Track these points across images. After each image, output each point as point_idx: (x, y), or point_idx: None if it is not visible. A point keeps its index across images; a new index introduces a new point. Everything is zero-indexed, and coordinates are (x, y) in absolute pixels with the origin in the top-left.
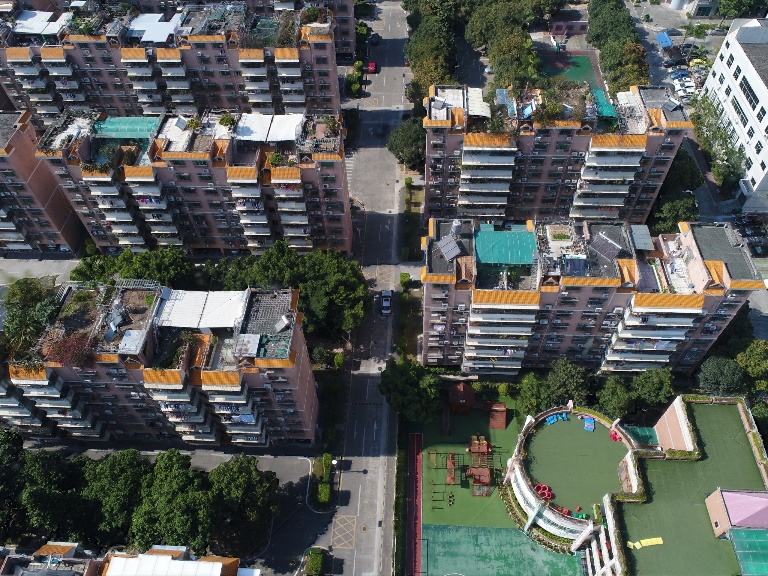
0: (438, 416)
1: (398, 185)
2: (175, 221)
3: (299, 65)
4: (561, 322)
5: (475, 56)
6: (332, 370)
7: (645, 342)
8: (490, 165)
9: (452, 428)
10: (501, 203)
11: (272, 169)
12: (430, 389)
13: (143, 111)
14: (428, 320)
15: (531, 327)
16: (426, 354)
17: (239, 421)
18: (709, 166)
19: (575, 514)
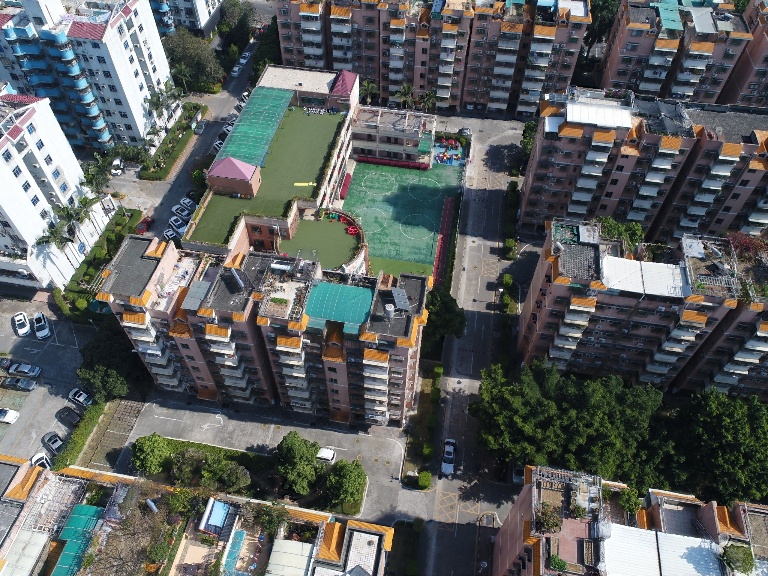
0: None
1: None
2: None
3: None
4: None
5: None
6: None
7: None
8: None
9: None
10: None
11: None
12: None
13: None
14: None
15: None
16: None
17: None
18: None
19: None
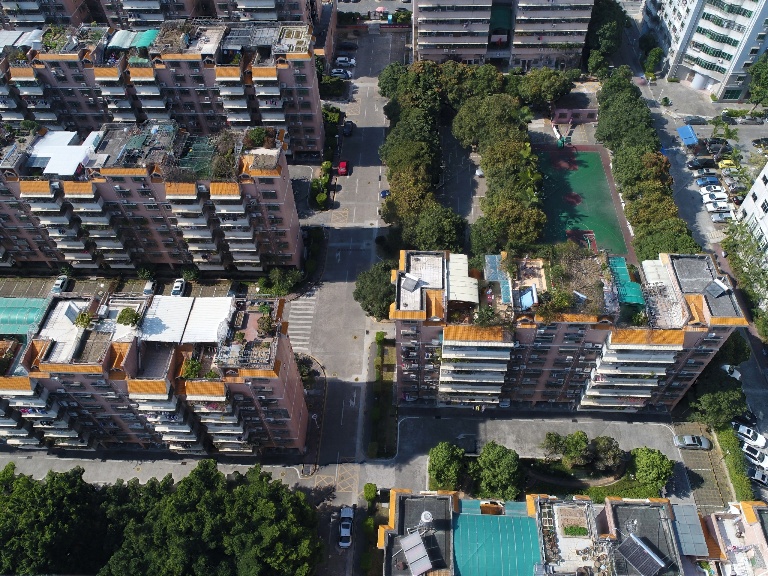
0: None
1: (368, 338)
2: (74, 423)
3: (241, 201)
4: None
5: (464, 152)
6: None
7: None
8: (478, 359)
9: None
10: (493, 391)
11: (187, 383)
12: None
13: (57, 245)
14: None
15: None
16: None
17: None
18: (751, 314)
19: None
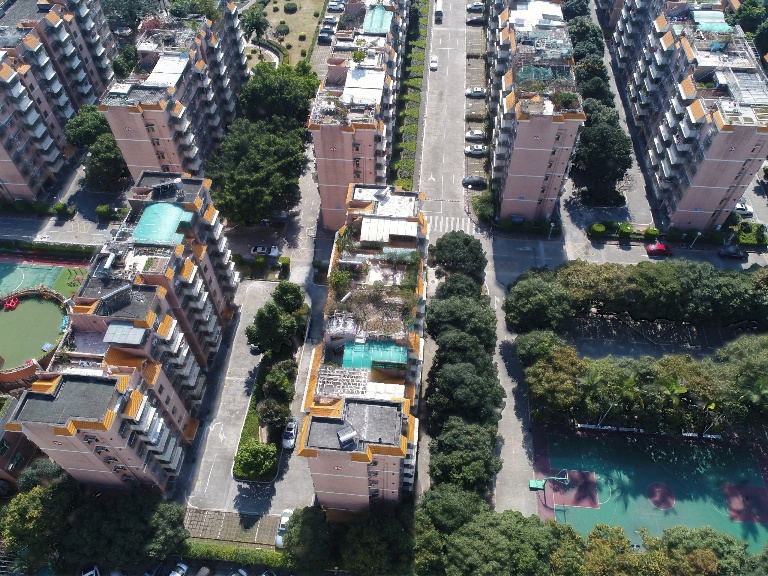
0: None
1: None
2: None
3: (506, 118)
4: None
5: None
6: None
7: None
8: None
9: None
10: None
11: None
12: None
13: None
14: None
15: None
16: None
17: None
18: None
19: None
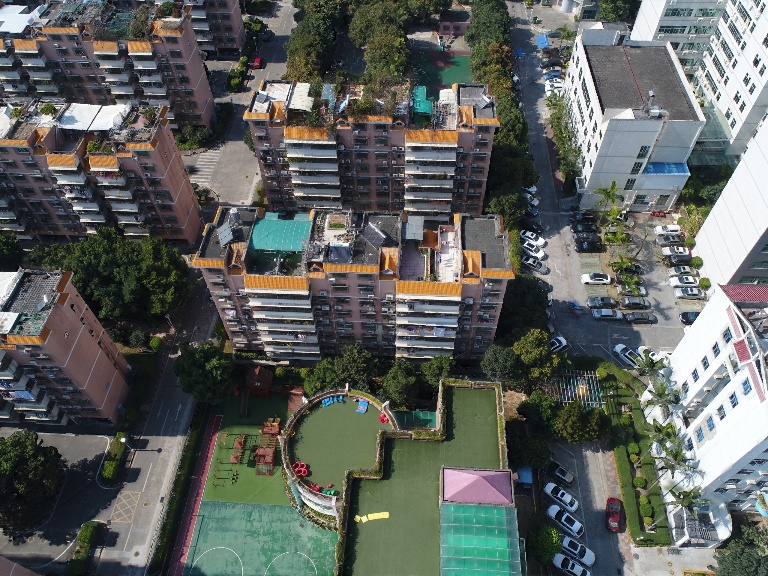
0: (238, 398)
1: (257, 177)
2: (13, 207)
3: (153, 58)
4: (344, 308)
5: (361, 54)
6: (150, 354)
7: (423, 329)
8: (314, 158)
9: (252, 410)
10: (335, 196)
11: (90, 157)
12: (216, 371)
13: None
14: (218, 305)
15: (310, 312)
16: (232, 339)
17: (19, 398)
18: (559, 164)
19: (324, 490)
